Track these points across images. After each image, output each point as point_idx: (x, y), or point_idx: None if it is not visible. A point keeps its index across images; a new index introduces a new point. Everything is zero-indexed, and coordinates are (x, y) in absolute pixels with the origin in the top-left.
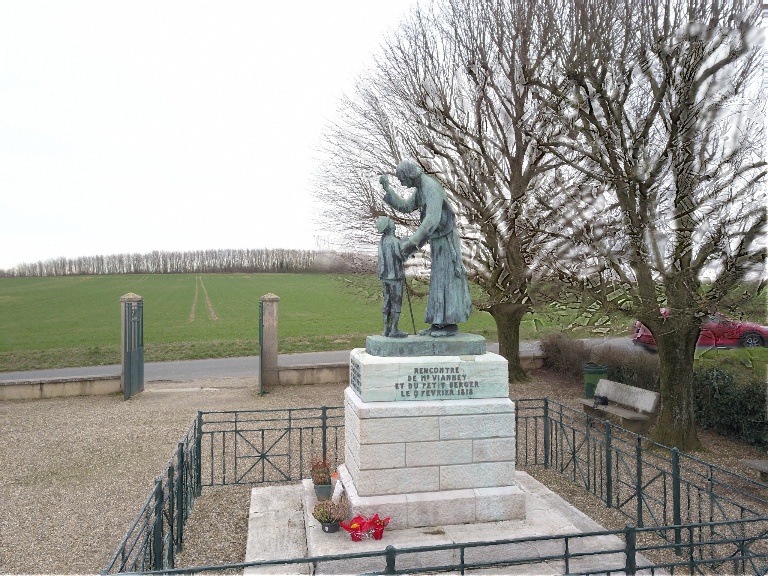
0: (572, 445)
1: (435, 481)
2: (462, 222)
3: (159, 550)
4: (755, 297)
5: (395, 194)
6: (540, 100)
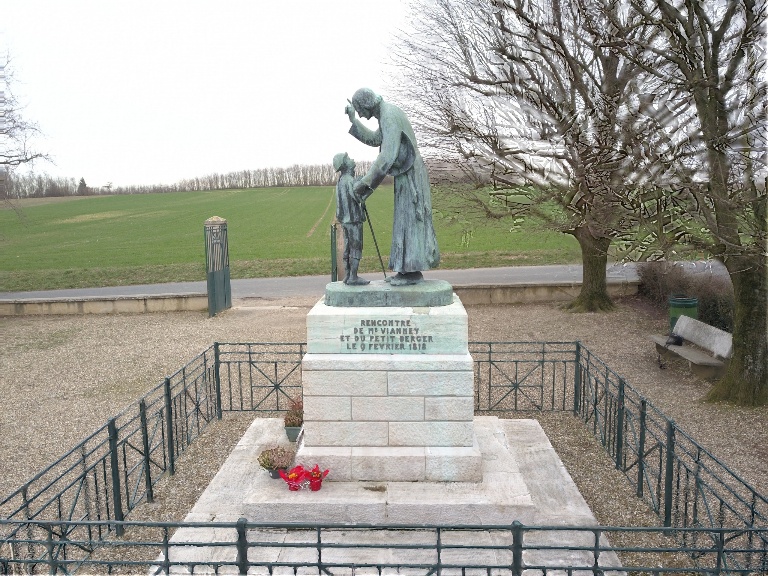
0: None
1: (383, 436)
2: (533, 137)
3: (116, 481)
4: None
5: (361, 125)
6: None
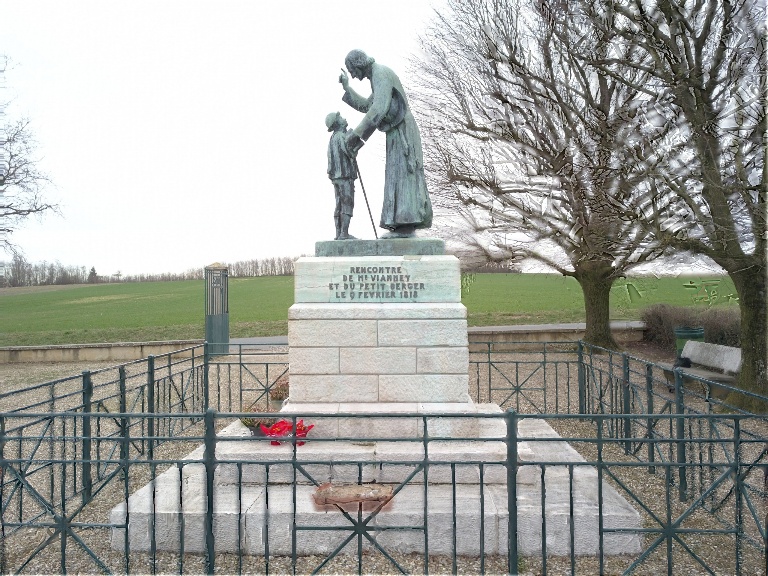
0: None
1: (373, 391)
2: (529, 173)
3: (87, 440)
4: None
5: (355, 93)
6: None
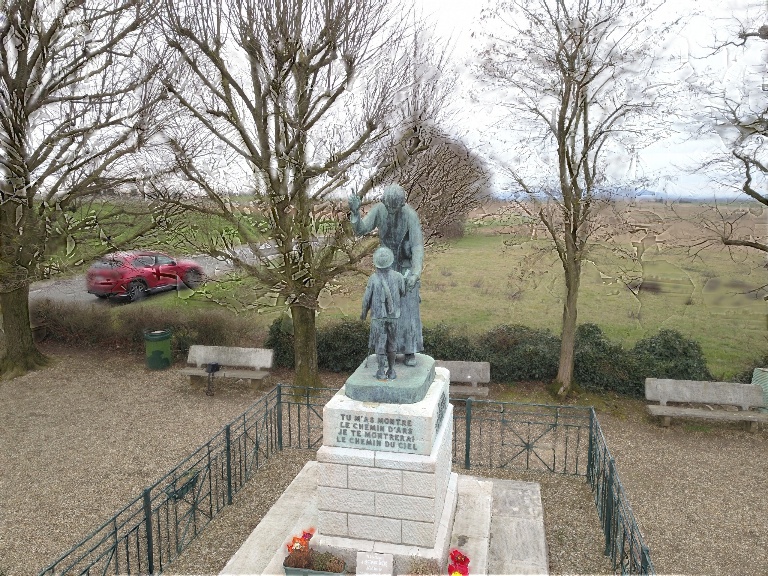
0: (242, 420)
1: None
2: None
3: None
4: (359, 264)
5: None
6: (180, 51)
